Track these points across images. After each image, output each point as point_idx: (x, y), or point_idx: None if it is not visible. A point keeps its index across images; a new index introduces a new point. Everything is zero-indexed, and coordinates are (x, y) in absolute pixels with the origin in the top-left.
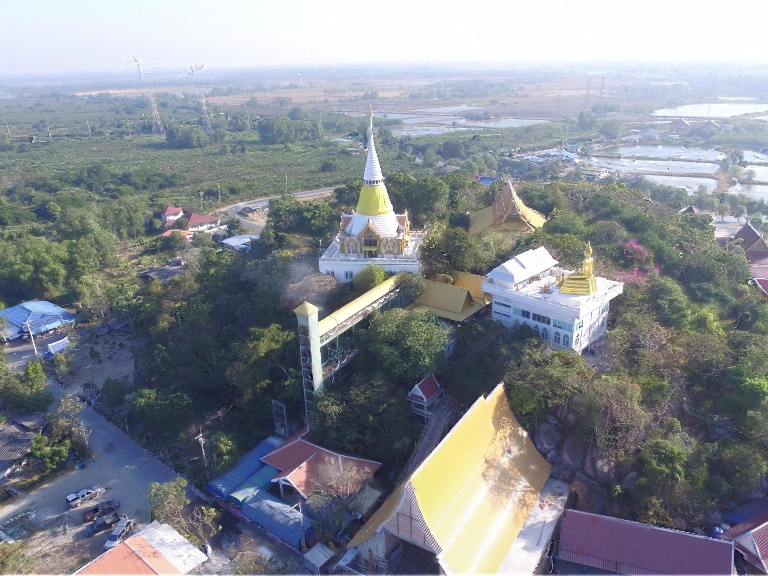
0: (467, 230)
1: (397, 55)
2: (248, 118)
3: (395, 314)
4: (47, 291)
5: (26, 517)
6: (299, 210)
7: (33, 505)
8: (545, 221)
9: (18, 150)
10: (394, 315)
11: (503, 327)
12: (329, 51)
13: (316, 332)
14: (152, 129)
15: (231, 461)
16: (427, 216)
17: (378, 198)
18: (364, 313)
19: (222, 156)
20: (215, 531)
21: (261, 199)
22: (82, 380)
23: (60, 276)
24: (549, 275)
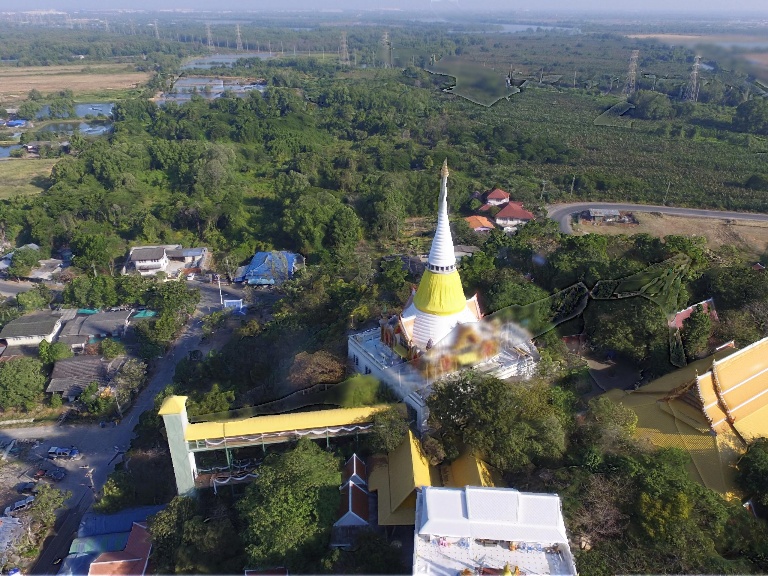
0: (661, 375)
1: (767, 57)
2: (747, 91)
3: (289, 463)
4: (304, 246)
5: (33, 444)
6: (510, 249)
7: (49, 437)
8: None
9: None
10: (288, 463)
11: None
12: (678, 40)
13: (179, 434)
14: (622, 90)
15: (109, 506)
16: (614, 327)
17: (432, 290)
18: (292, 435)
19: (655, 137)
20: (1, 567)
21: (624, 204)
22: (216, 344)
23: (316, 237)
24: (545, 551)
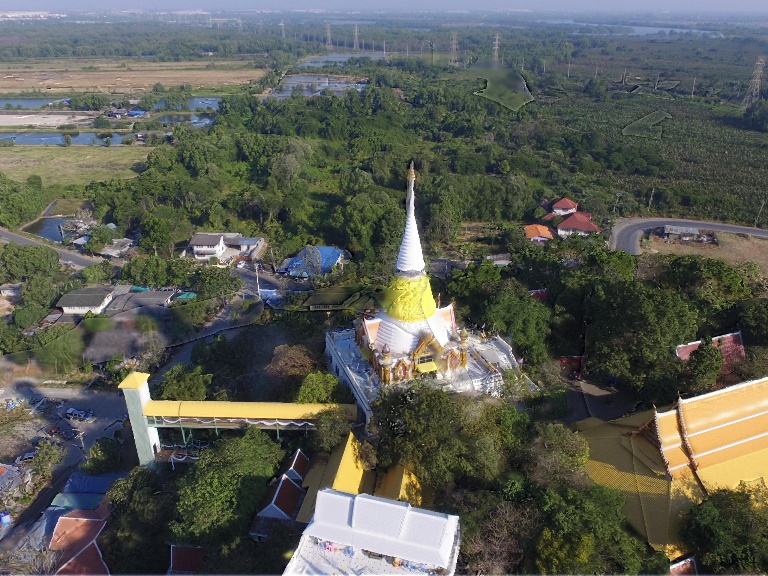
0: (649, 409)
1: None
2: None
3: (226, 448)
4: (352, 243)
5: (58, 404)
6: (535, 261)
7: (73, 399)
8: None
9: (597, 99)
10: None
11: (239, 574)
12: (746, 45)
13: (138, 408)
14: (743, 99)
15: (93, 468)
16: (610, 351)
17: None
18: (243, 423)
19: None
20: None
21: (709, 222)
22: None
23: (363, 235)
24: (428, 572)
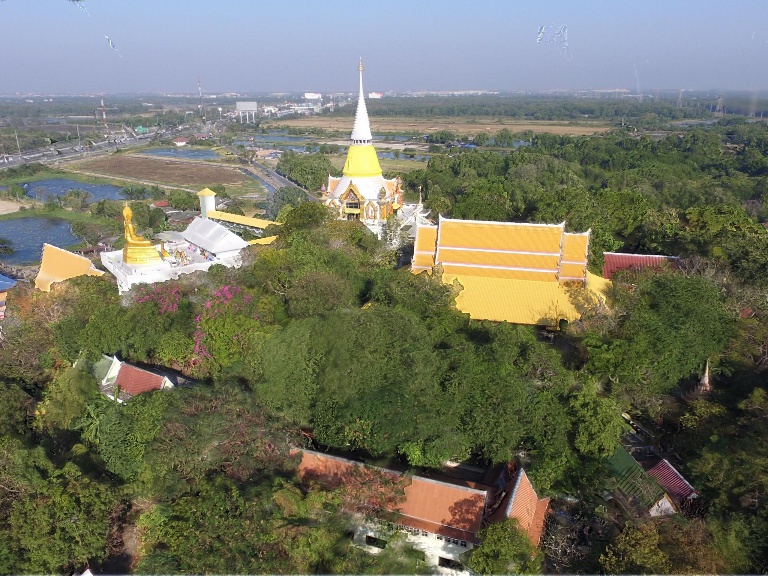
0: None
1: None
2: None
3: None
4: None
5: None
6: None
7: None
8: (533, 316)
9: None
10: None
11: None
12: None
13: None
14: None
15: None
16: None
17: None
18: None
19: None
20: None
21: None
22: None
23: None
24: None
